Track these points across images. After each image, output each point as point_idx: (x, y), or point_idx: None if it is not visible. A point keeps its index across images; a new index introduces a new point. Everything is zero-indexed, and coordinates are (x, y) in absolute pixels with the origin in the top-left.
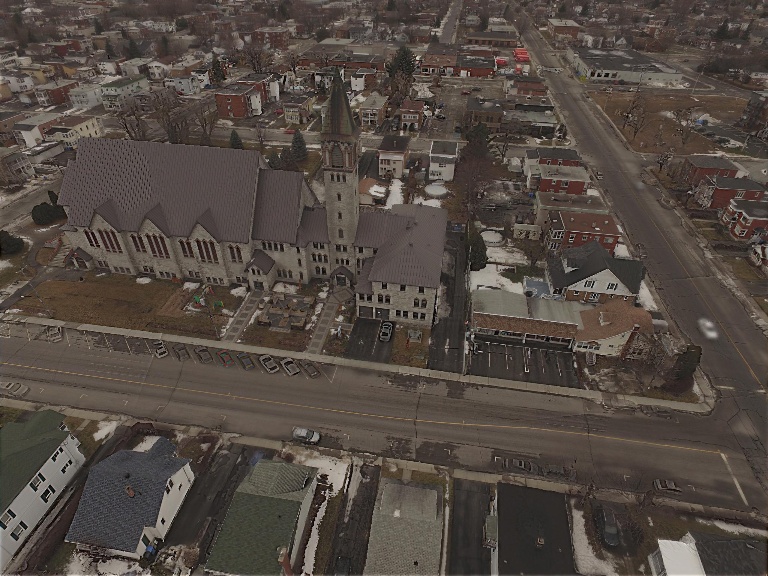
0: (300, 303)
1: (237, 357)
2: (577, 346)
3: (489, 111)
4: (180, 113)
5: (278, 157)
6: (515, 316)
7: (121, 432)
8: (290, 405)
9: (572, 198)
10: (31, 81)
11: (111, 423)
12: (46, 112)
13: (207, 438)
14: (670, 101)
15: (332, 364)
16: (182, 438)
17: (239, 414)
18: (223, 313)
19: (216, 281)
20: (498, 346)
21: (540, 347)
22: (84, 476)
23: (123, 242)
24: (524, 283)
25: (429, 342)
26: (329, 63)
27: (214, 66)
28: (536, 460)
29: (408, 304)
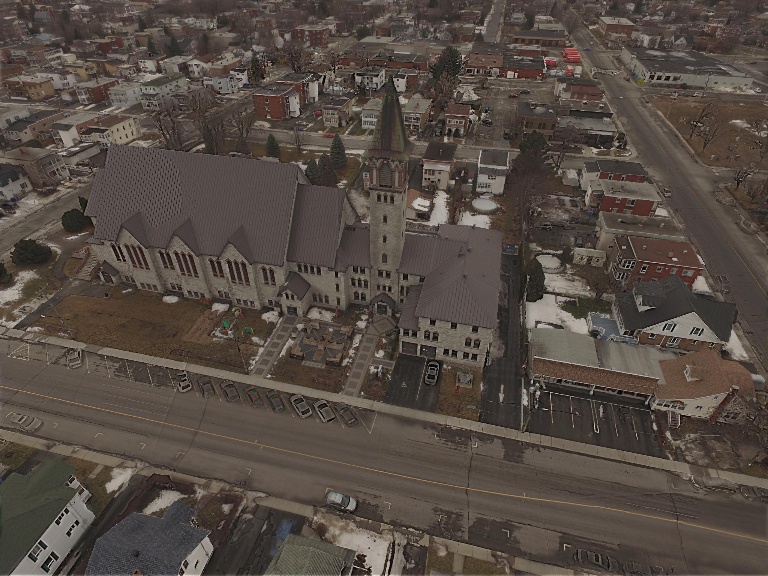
0: (336, 333)
1: (266, 396)
2: (657, 404)
3: (542, 117)
4: (217, 113)
5: (316, 165)
6: (583, 364)
7: (136, 483)
8: (323, 460)
9: (642, 221)
10: (73, 78)
11: (126, 471)
12: (86, 110)
13: (230, 497)
14: (740, 108)
15: (371, 410)
16: (202, 495)
17: (266, 468)
18: (253, 341)
19: (246, 303)
20: (561, 397)
21: (611, 401)
22: (92, 537)
23: (150, 258)
24: (589, 320)
25: (481, 388)
26: (370, 63)
27: (253, 65)
28: (614, 552)
29: (458, 343)
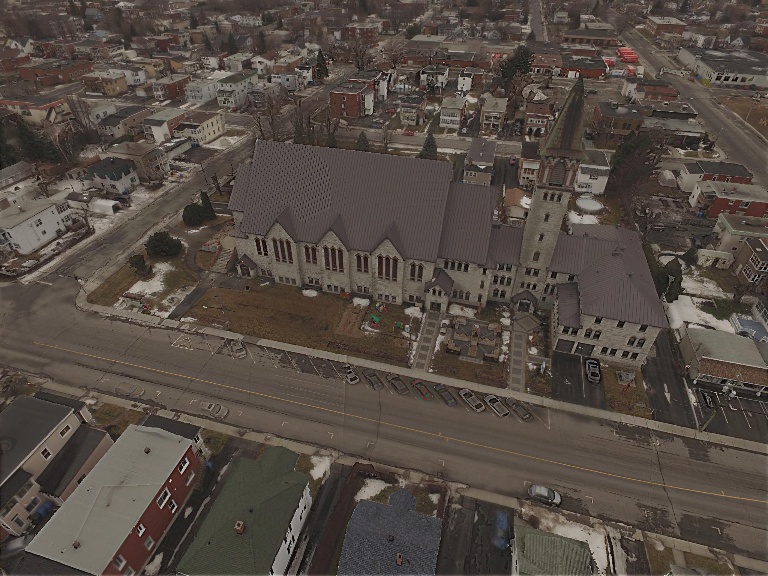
0: (483, 329)
1: (435, 389)
2: None
3: (627, 117)
4: (291, 110)
5: None
6: (753, 365)
7: (337, 471)
8: (512, 453)
9: None
10: (144, 75)
11: (324, 459)
12: (162, 106)
13: (434, 487)
14: None
15: (542, 406)
16: (405, 484)
17: (458, 460)
18: (404, 336)
19: (387, 298)
20: None
21: None
22: (314, 522)
23: (296, 253)
24: (734, 321)
25: (645, 387)
26: (433, 61)
27: (319, 63)
28: None
29: (620, 342)
